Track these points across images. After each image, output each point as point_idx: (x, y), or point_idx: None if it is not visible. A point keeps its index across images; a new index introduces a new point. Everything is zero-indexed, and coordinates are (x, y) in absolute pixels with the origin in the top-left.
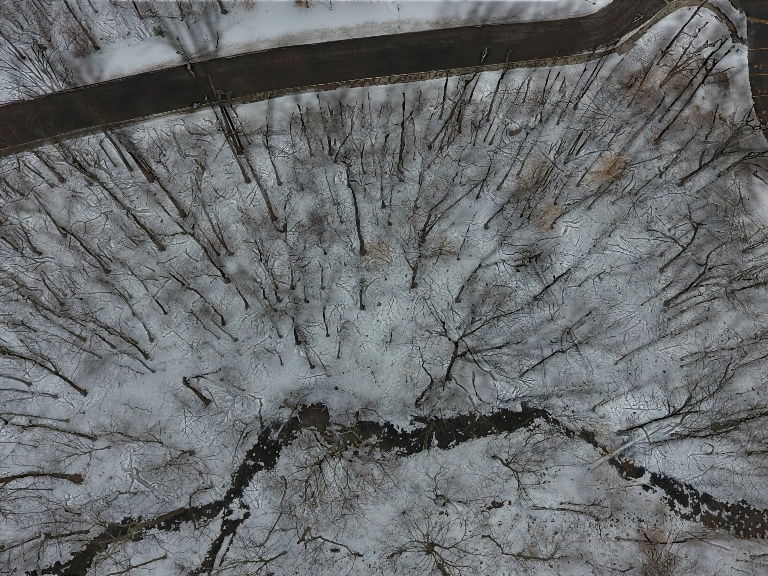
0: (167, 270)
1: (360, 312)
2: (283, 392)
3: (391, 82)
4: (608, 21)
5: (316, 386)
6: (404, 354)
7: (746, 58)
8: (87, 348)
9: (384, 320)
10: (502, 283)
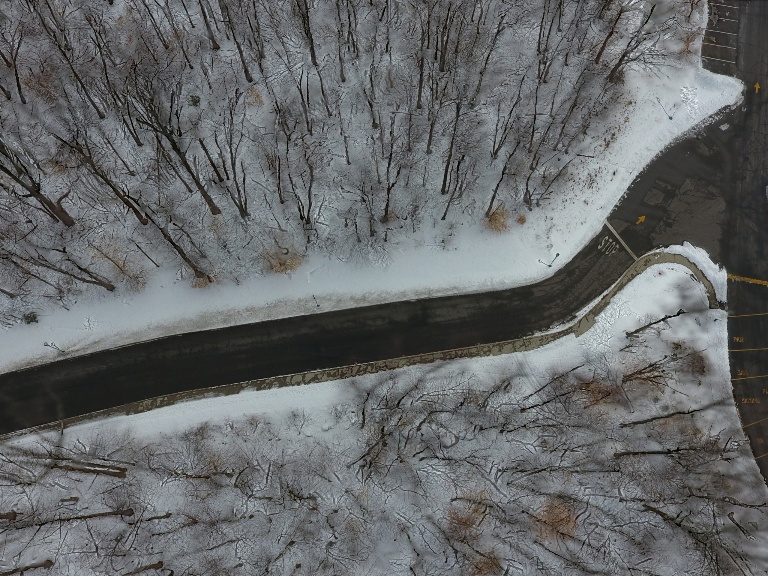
0: None
1: None
2: None
3: (305, 381)
4: (565, 288)
5: None
6: None
7: (725, 329)
8: None
9: None
10: None
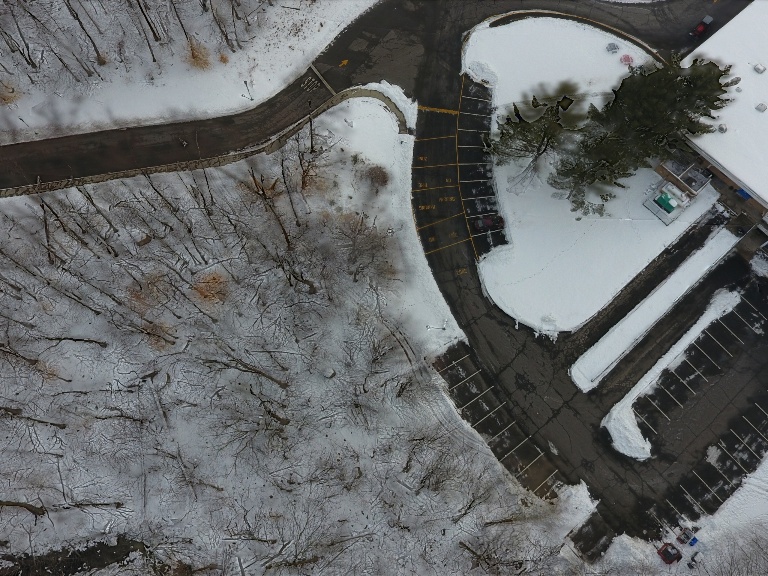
0: None
1: None
2: None
3: (18, 194)
4: (265, 117)
5: None
6: None
7: (411, 150)
8: None
9: None
10: None
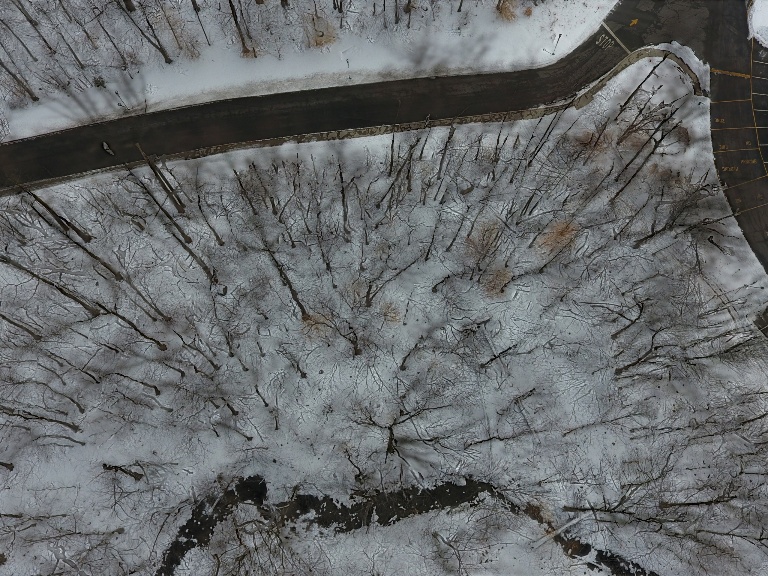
0: (97, 341)
1: (301, 380)
2: (218, 466)
3: (340, 137)
4: (567, 72)
5: (253, 458)
6: (345, 425)
7: (708, 111)
8: (14, 420)
9: (325, 389)
10: (449, 350)
